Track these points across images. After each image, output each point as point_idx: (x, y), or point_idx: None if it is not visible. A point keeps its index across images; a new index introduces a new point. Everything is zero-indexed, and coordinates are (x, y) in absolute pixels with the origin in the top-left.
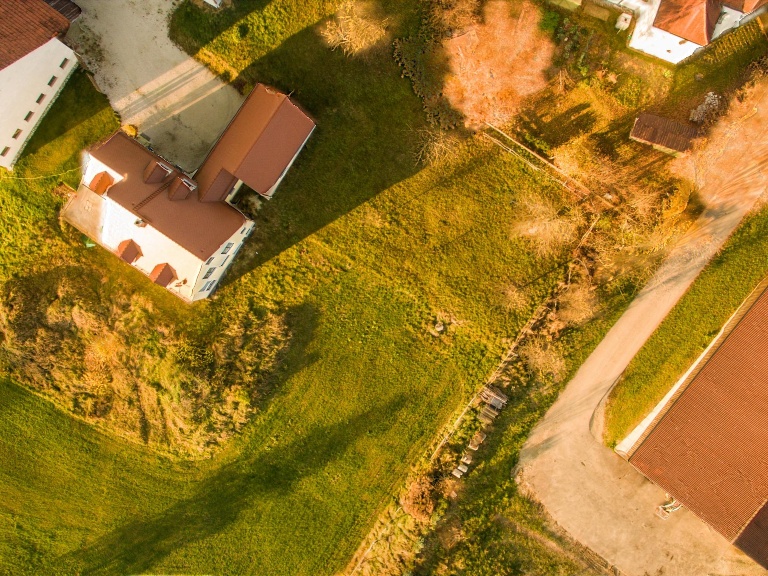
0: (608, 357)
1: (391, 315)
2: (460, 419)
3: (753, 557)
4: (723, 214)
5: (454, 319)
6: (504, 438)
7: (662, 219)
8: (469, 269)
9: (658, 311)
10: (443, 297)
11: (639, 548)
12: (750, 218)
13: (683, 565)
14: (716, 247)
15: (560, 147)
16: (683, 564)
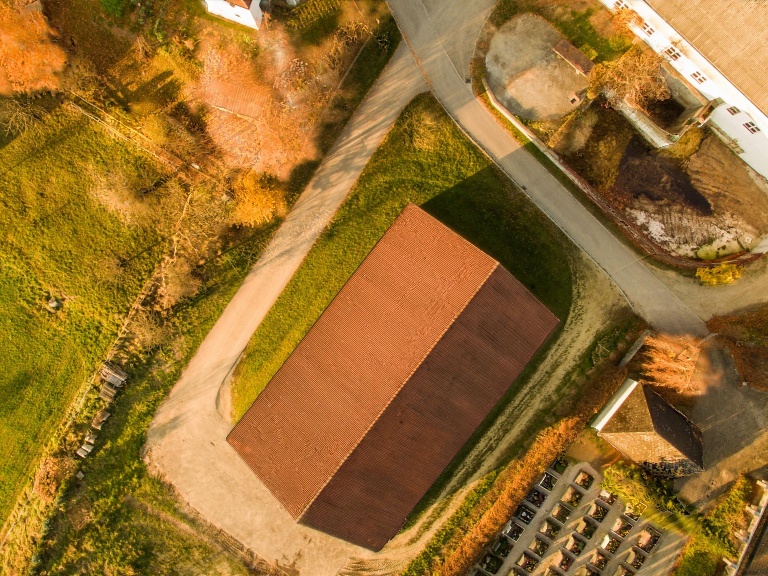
0: (228, 334)
1: (3, 291)
2: (85, 398)
3: (343, 538)
4: (330, 186)
5: (65, 294)
6: (130, 417)
7: (245, 189)
8: (72, 243)
9: (274, 286)
10: (50, 272)
11: (275, 531)
12: (357, 190)
13: (322, 548)
14: (326, 220)
15: (149, 116)
16: (322, 547)
